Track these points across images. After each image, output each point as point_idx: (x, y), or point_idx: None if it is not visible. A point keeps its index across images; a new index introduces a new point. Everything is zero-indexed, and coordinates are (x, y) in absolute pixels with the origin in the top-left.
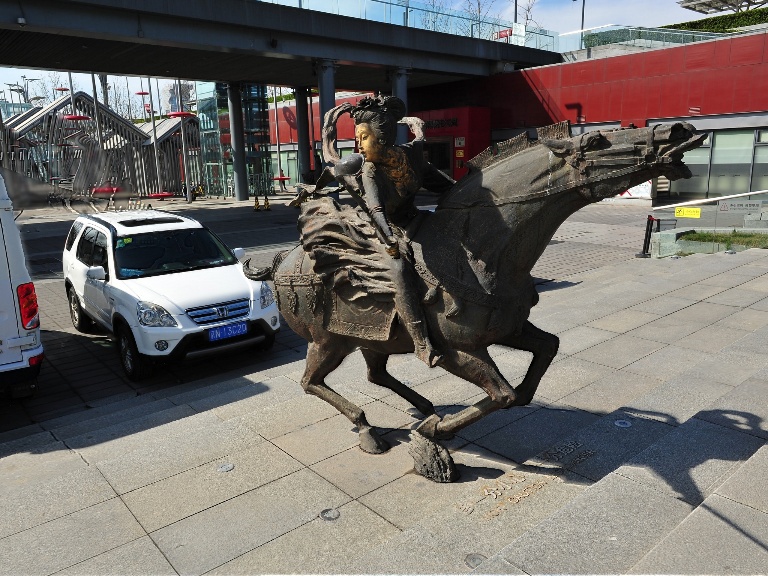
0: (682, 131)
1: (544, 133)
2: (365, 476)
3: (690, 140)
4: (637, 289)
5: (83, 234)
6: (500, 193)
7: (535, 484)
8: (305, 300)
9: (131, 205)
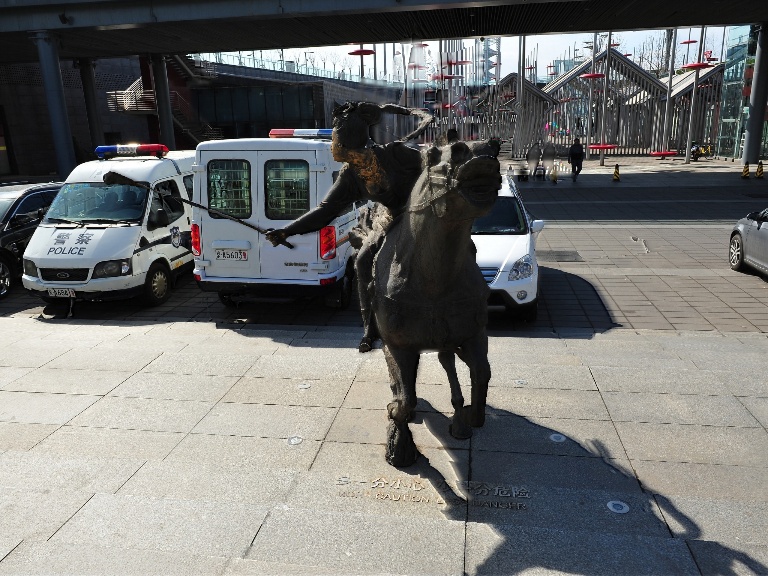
0: (464, 151)
1: (441, 141)
2: (356, 431)
3: (465, 163)
4: None
5: None
6: None
7: (418, 497)
8: None
9: (556, 166)
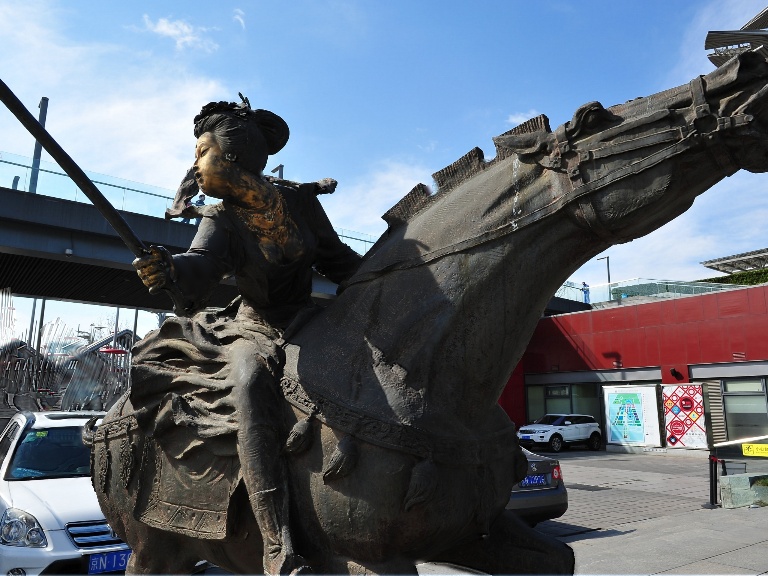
0: (762, 65)
1: None
2: None
3: None
4: (713, 536)
5: (8, 431)
6: (432, 241)
7: None
8: (119, 464)
9: None
